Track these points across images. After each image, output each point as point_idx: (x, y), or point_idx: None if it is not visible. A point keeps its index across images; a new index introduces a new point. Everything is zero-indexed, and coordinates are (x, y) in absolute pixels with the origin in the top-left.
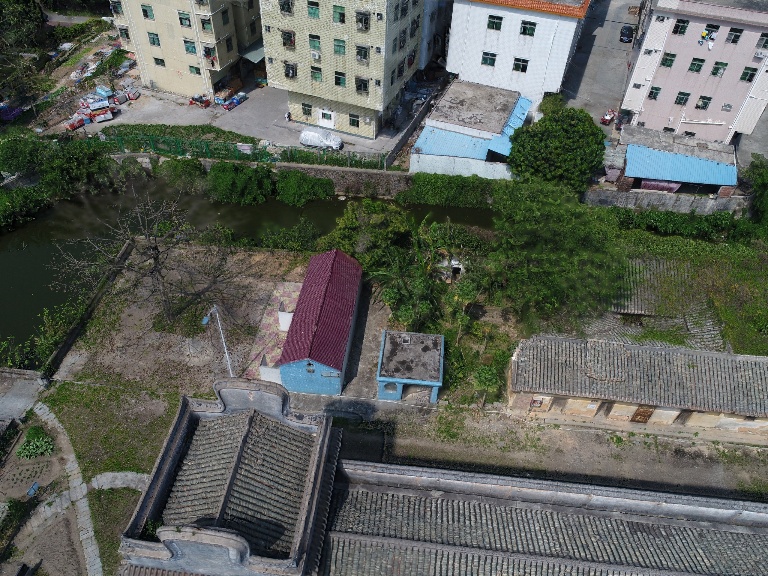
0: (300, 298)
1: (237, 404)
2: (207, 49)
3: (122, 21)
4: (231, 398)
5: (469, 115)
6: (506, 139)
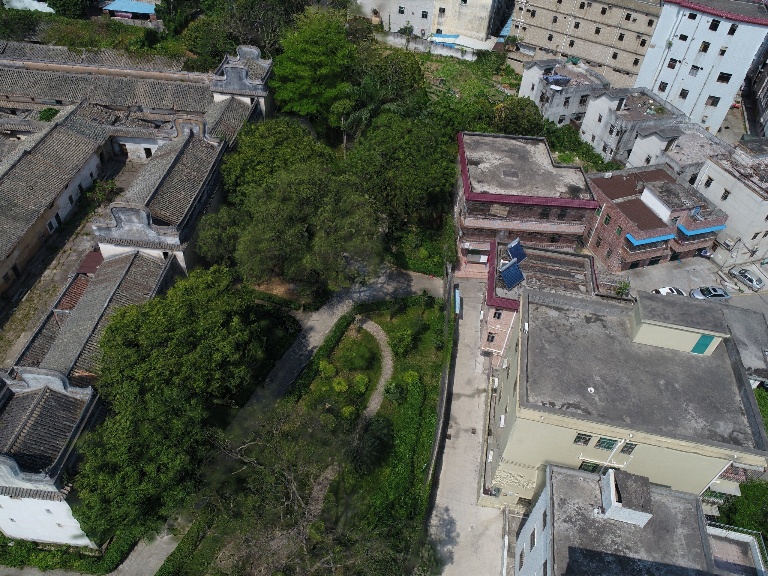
0: None
1: None
2: None
3: None
4: None
5: None
6: None
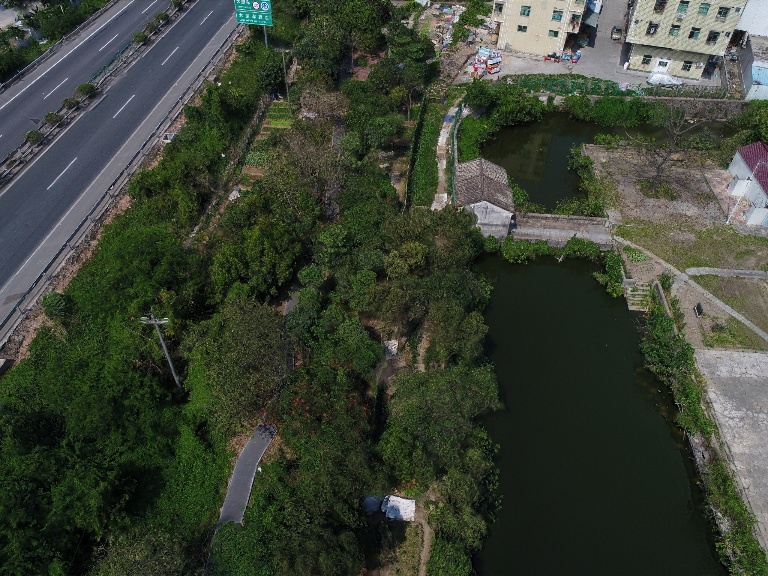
0: None
1: None
2: (574, 16)
3: None
4: None
5: None
6: None
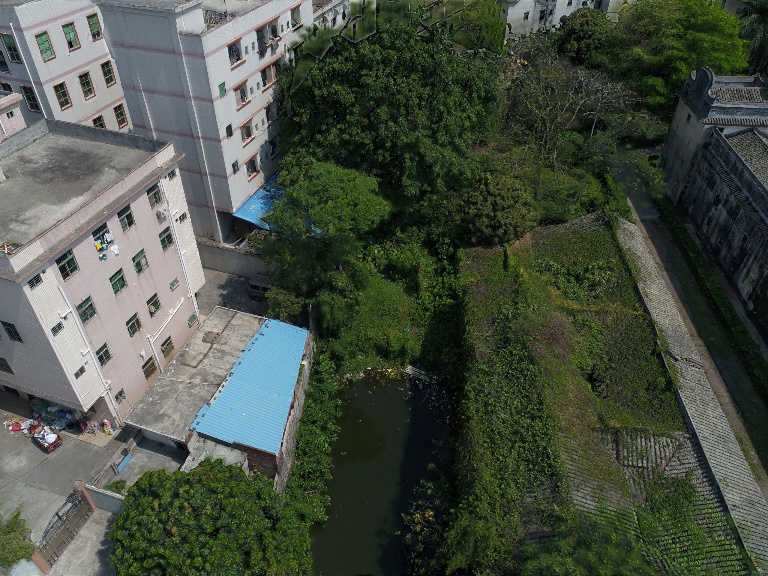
0: None
1: None
2: None
3: None
4: None
5: None
6: None
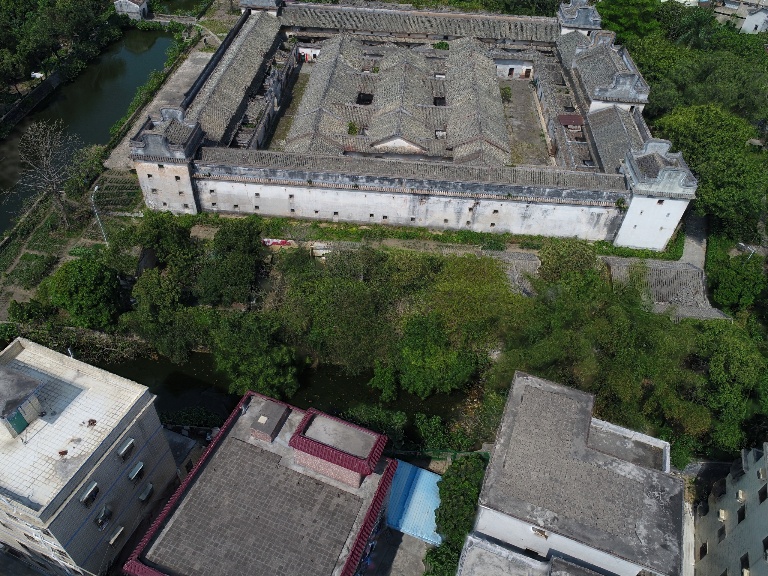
0: None
1: None
2: None
3: None
4: None
5: None
6: None
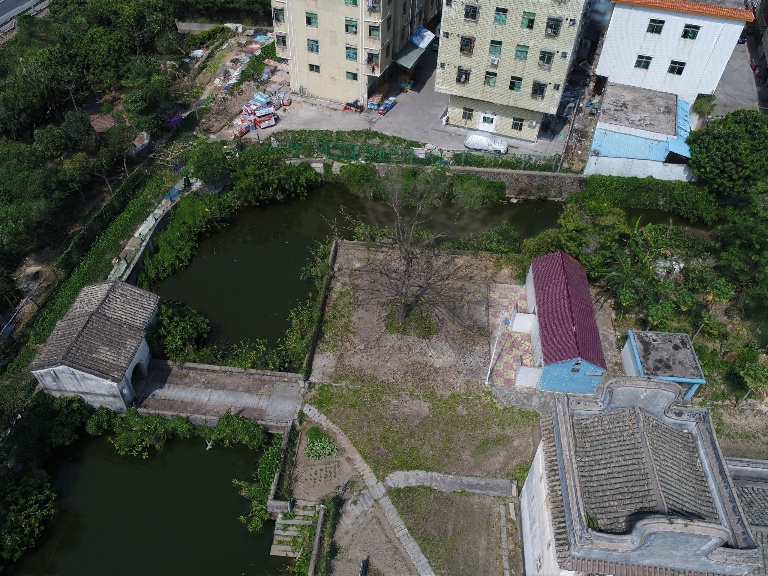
0: (539, 299)
1: (622, 402)
2: (370, 55)
3: (281, 28)
4: (620, 396)
5: (637, 117)
6: (681, 141)
